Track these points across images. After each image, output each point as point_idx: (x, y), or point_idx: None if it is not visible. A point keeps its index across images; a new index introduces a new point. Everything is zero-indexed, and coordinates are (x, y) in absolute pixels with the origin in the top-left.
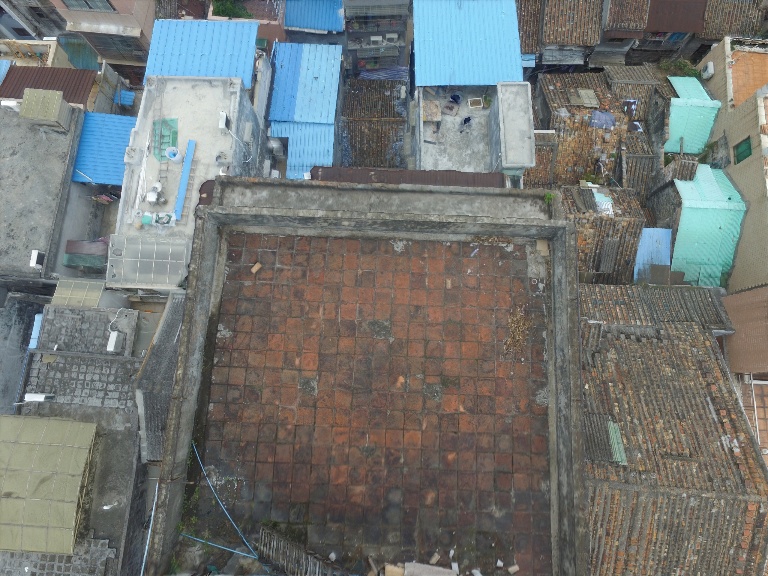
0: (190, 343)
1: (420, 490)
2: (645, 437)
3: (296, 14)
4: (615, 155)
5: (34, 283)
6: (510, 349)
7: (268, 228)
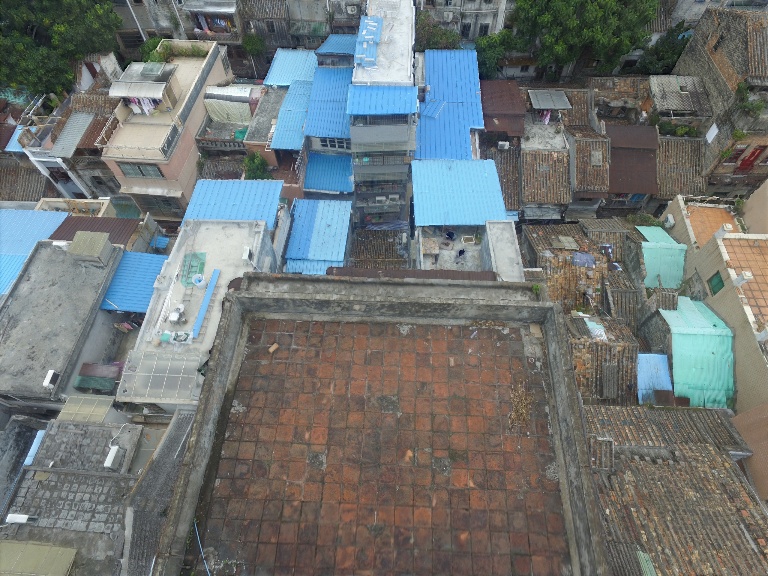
0: (206, 411)
1: (432, 575)
2: (682, 571)
3: (314, 179)
4: (600, 289)
5: (38, 409)
6: (515, 423)
7: (287, 315)
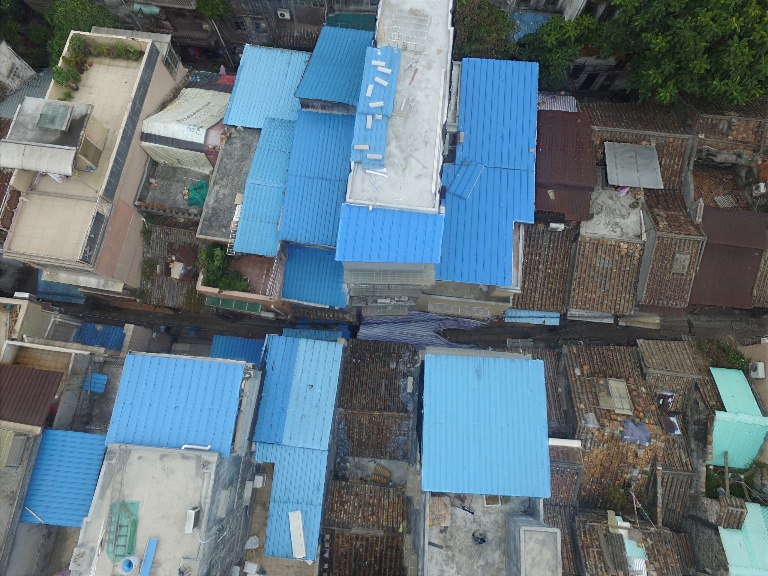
0: None
1: None
2: None
3: (295, 285)
4: (649, 474)
5: None
6: None
7: None
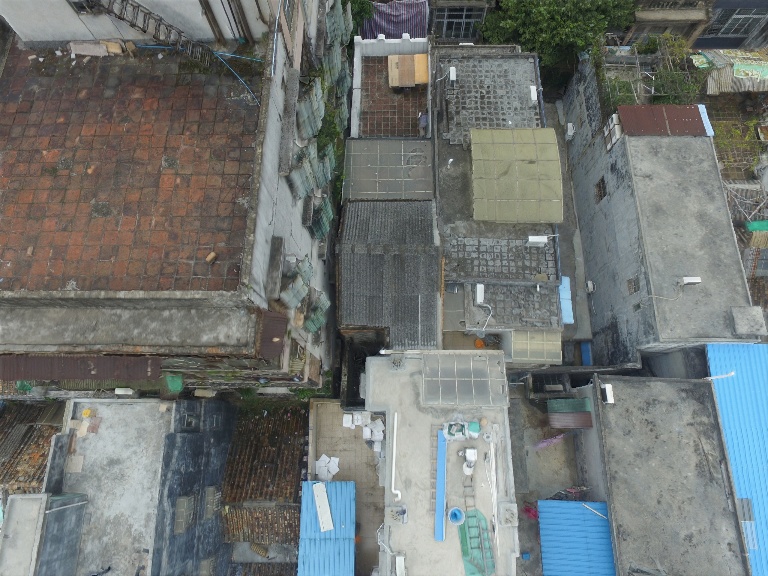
0: (252, 174)
1: (89, 98)
2: None
3: None
4: None
5: None
6: None
7: None
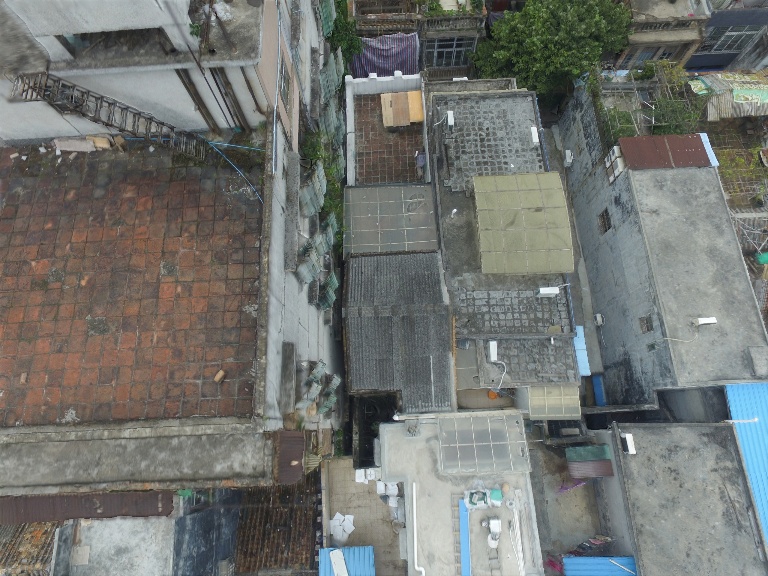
0: (259, 286)
1: (78, 199)
2: None
3: None
4: None
5: None
6: None
7: None
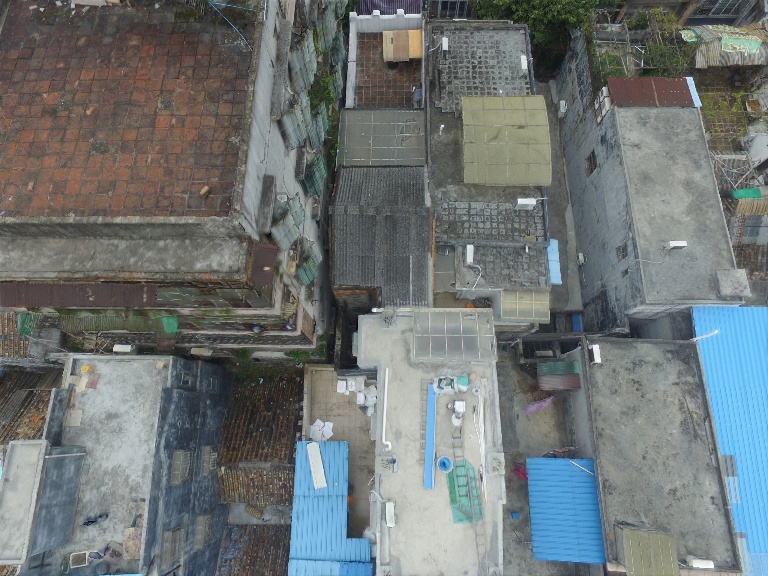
0: None
1: (88, 45)
2: None
3: None
4: None
5: None
6: None
7: None
